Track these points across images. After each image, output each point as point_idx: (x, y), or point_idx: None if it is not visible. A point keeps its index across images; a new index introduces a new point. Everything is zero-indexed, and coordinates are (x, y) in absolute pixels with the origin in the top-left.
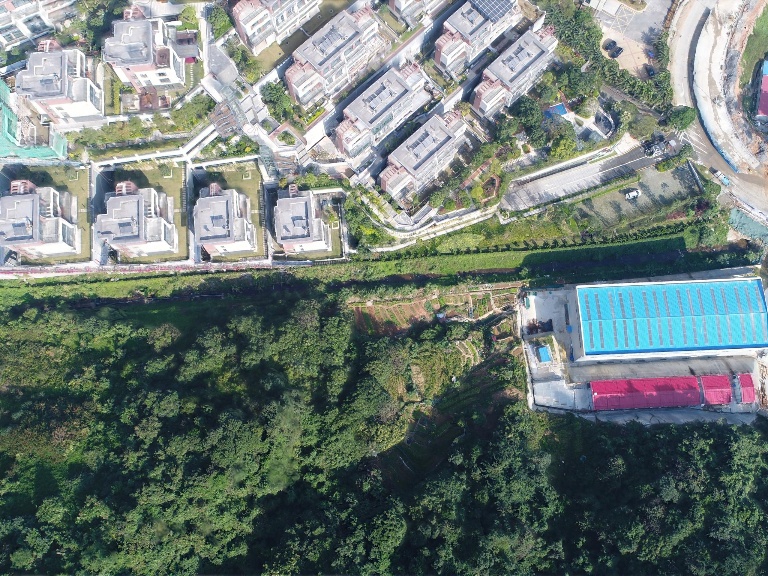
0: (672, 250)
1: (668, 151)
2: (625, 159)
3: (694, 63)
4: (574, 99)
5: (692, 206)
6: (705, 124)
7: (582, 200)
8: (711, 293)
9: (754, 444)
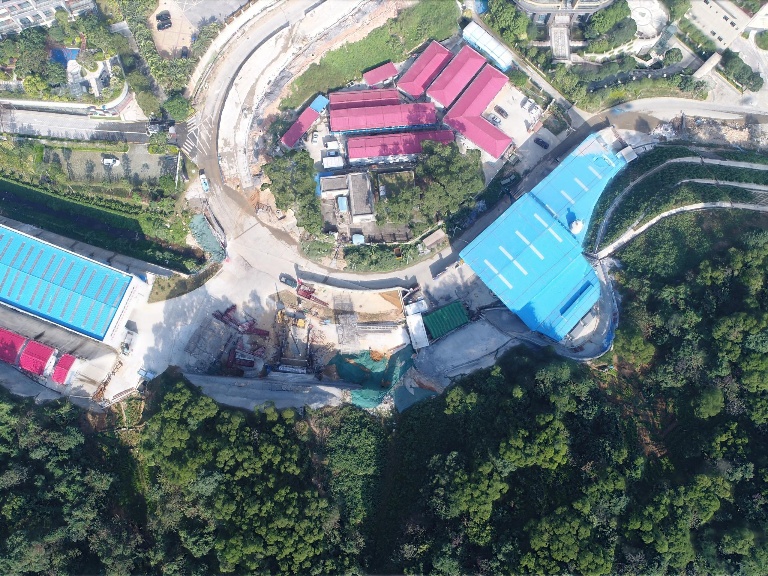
0: (130, 230)
1: (170, 137)
2: (125, 127)
3: (243, 67)
4: (92, 50)
5: (156, 195)
6: (221, 127)
7: (61, 147)
8: (82, 270)
9: (8, 413)
